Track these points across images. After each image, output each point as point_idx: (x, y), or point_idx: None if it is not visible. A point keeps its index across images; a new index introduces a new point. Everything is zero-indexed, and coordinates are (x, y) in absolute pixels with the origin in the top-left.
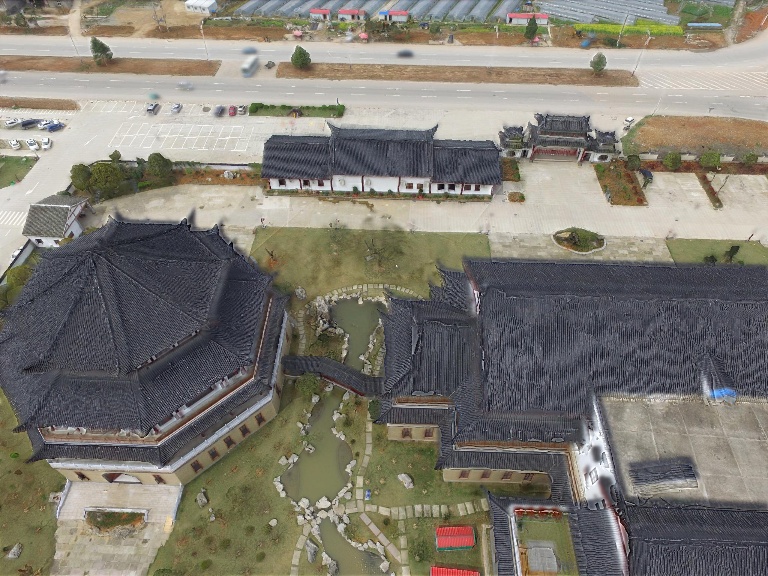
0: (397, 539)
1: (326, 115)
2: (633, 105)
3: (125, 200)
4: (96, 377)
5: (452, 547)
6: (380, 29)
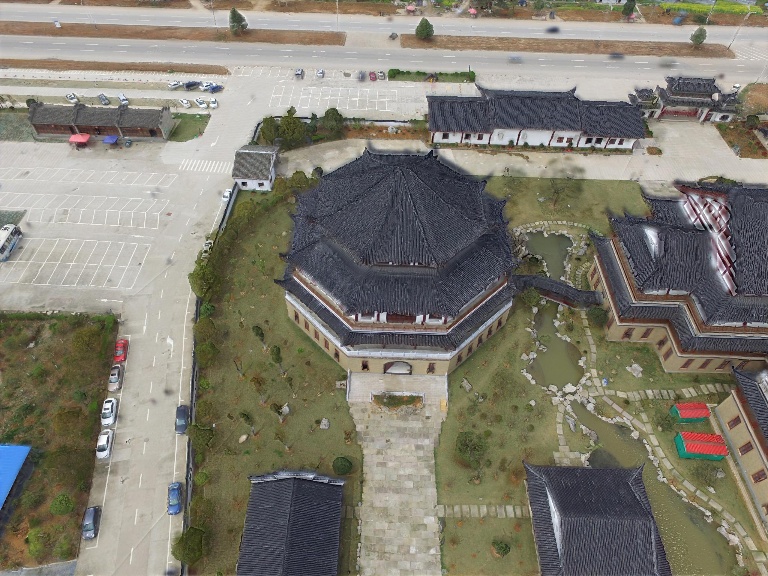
0: (638, 415)
1: (459, 81)
2: (735, 74)
3: (303, 152)
4: (402, 273)
5: (692, 418)
6: (483, 6)
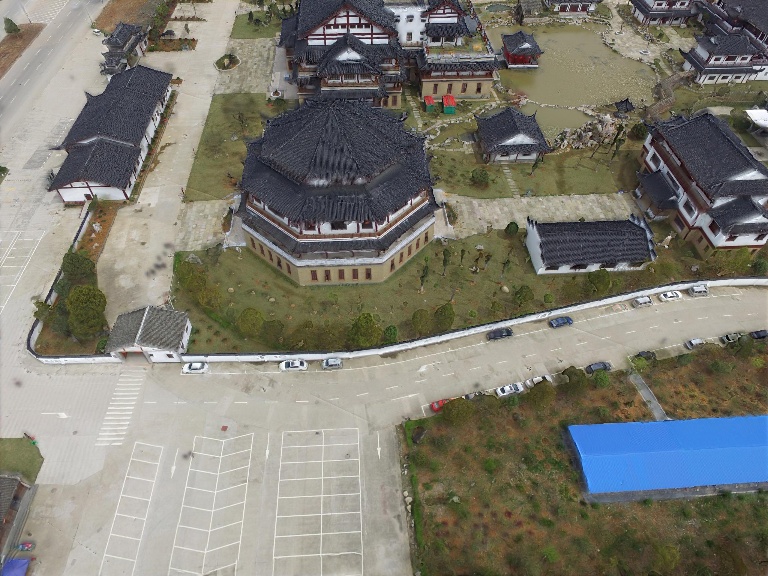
0: (432, 123)
1: None
2: (73, 30)
3: (111, 309)
4: None
5: (434, 103)
6: None
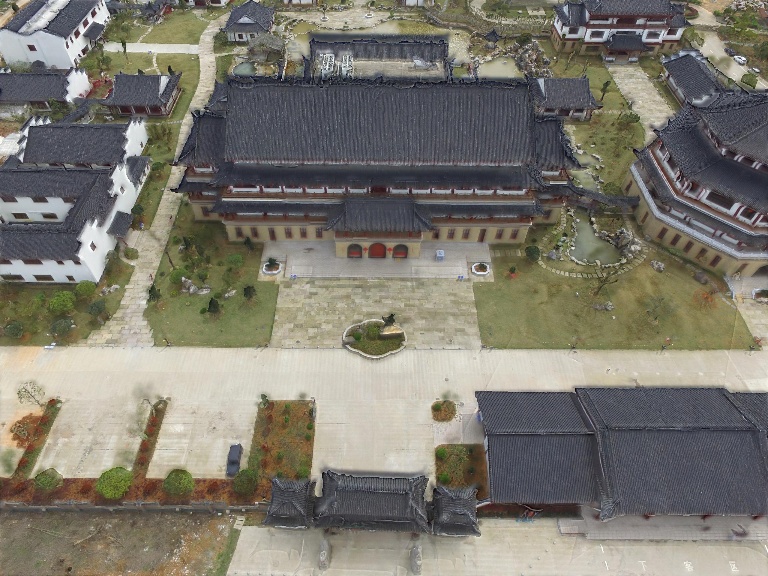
0: None
1: None
2: None
3: None
4: None
5: None
6: None
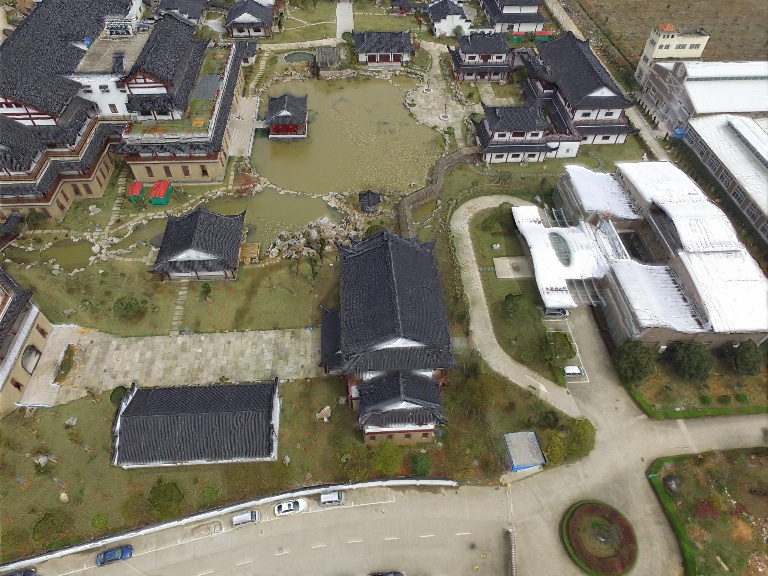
0: (131, 218)
1: None
2: None
3: None
4: None
5: None
6: None
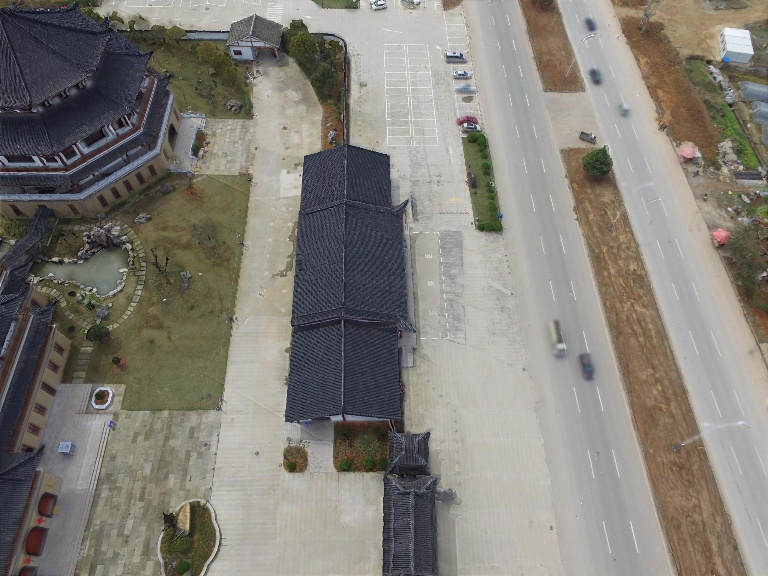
0: None
1: (478, 212)
2: None
3: (298, 75)
4: None
5: None
6: None
